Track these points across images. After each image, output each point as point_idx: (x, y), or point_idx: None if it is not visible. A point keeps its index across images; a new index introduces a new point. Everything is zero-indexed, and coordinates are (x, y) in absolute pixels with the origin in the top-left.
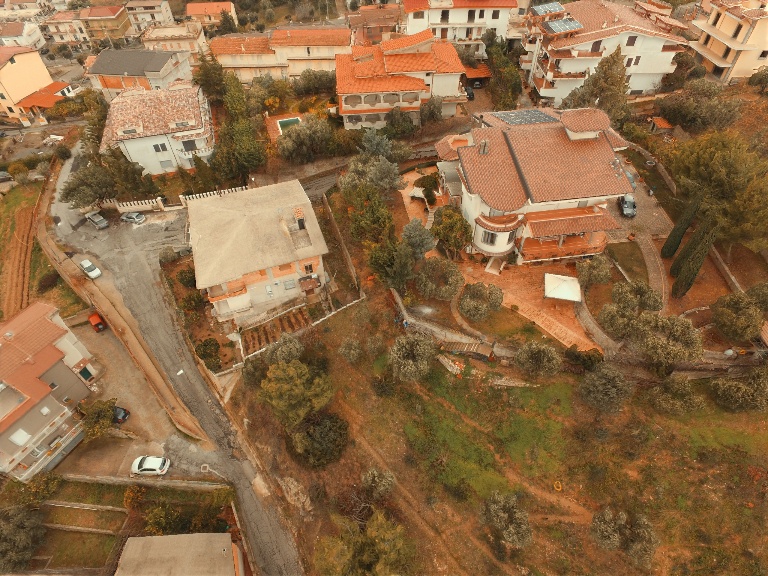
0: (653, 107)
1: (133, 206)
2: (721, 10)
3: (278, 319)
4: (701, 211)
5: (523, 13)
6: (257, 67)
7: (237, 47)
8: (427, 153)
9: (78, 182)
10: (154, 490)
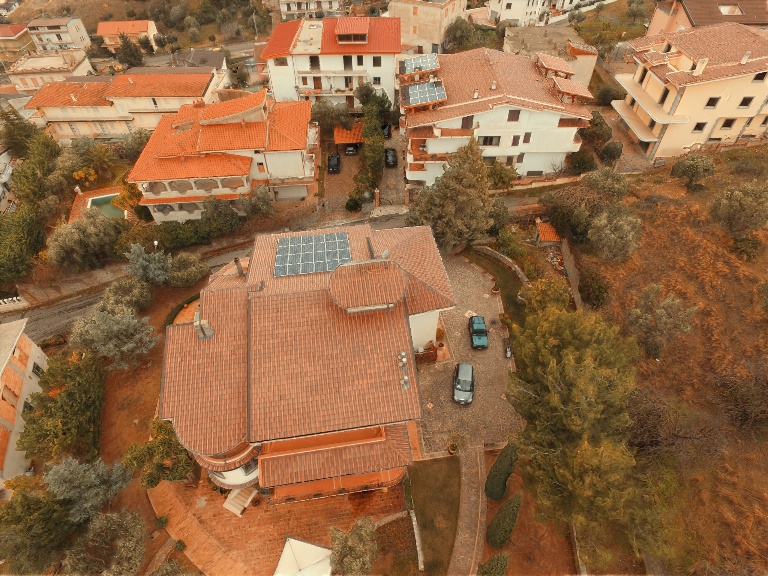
0: None
1: None
2: (646, 66)
3: None
4: (522, 460)
5: (437, 49)
6: (94, 121)
7: (68, 96)
8: None
9: None
10: None
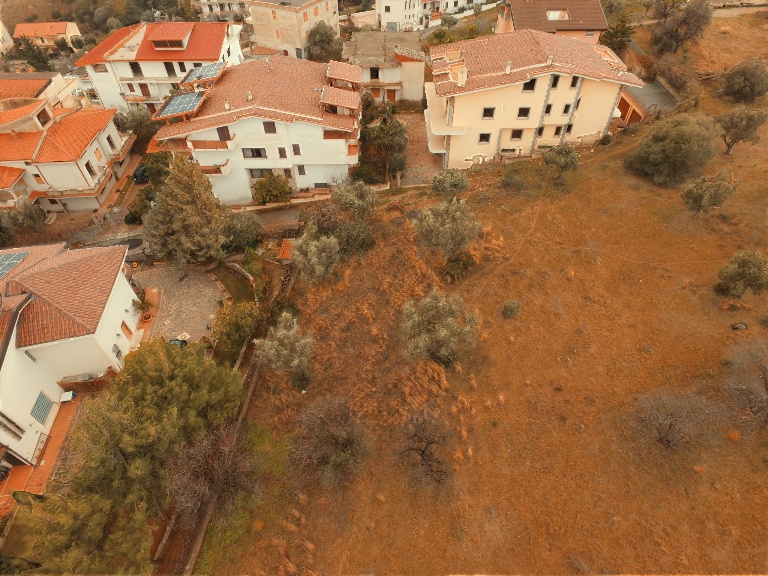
0: (299, 220)
1: None
2: None
3: None
4: None
5: (300, 54)
6: None
7: None
8: None
9: None
10: None
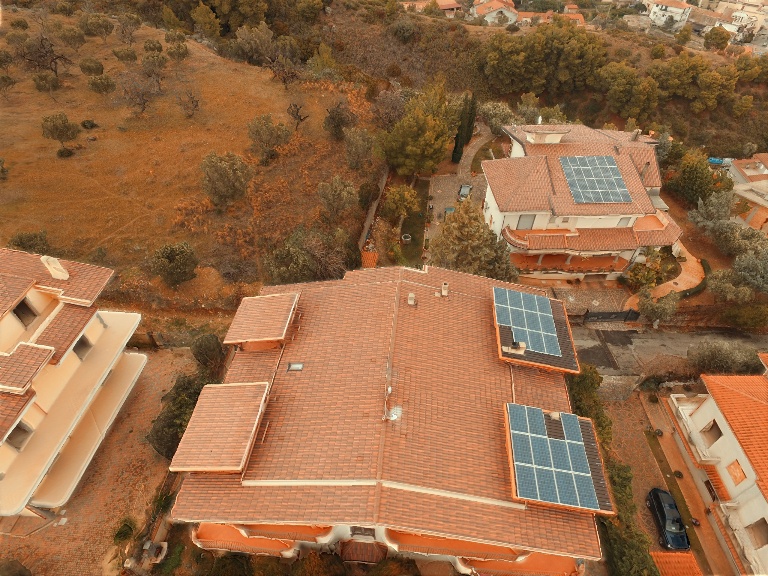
0: None
1: None
2: None
3: None
4: None
5: None
6: None
7: None
8: (686, 354)
9: None
10: None
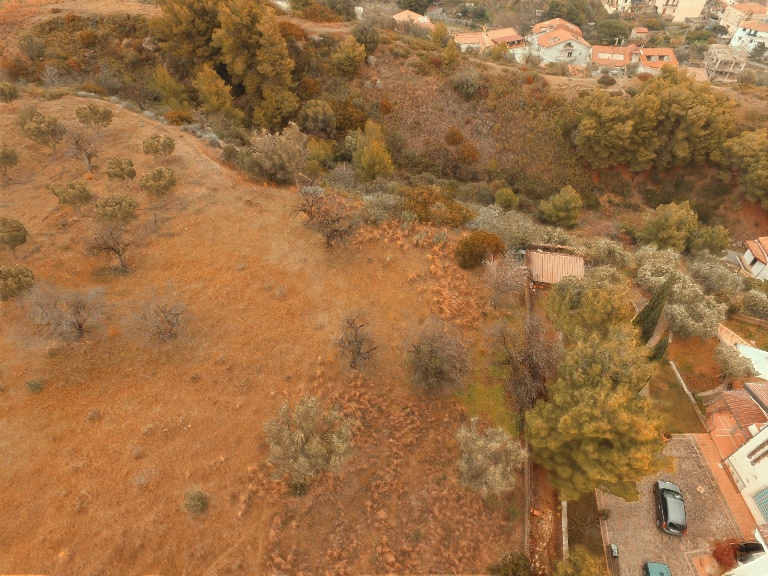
0: None
1: None
2: None
3: None
4: None
5: None
6: None
7: None
8: None
9: None
10: None
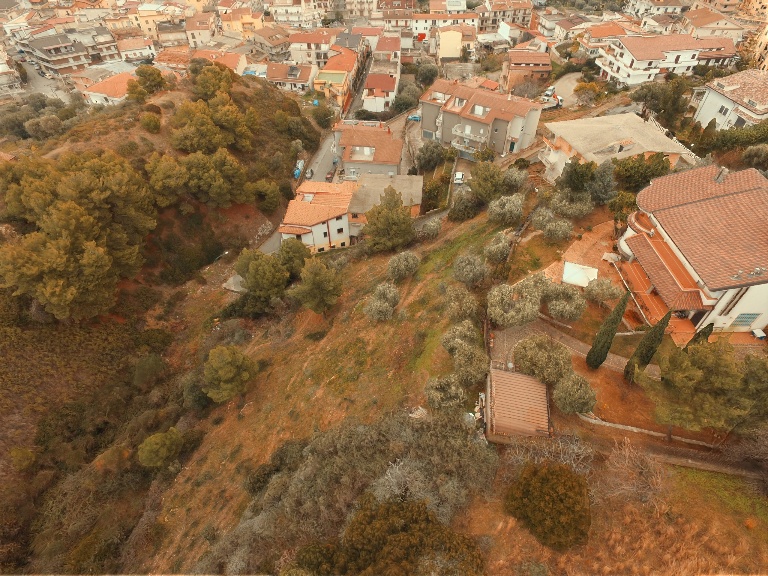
0: None
1: (654, 124)
2: None
3: (551, 185)
4: None
5: None
6: None
7: None
8: None
9: (650, 86)
10: (448, 186)
